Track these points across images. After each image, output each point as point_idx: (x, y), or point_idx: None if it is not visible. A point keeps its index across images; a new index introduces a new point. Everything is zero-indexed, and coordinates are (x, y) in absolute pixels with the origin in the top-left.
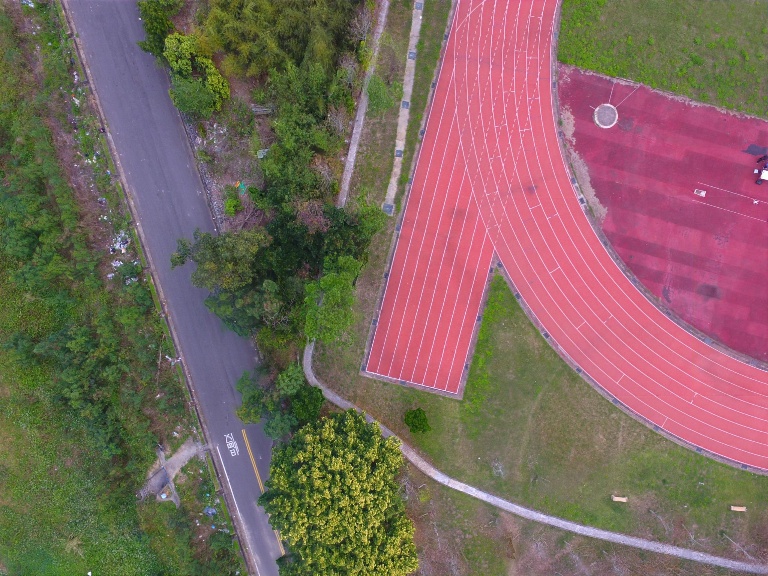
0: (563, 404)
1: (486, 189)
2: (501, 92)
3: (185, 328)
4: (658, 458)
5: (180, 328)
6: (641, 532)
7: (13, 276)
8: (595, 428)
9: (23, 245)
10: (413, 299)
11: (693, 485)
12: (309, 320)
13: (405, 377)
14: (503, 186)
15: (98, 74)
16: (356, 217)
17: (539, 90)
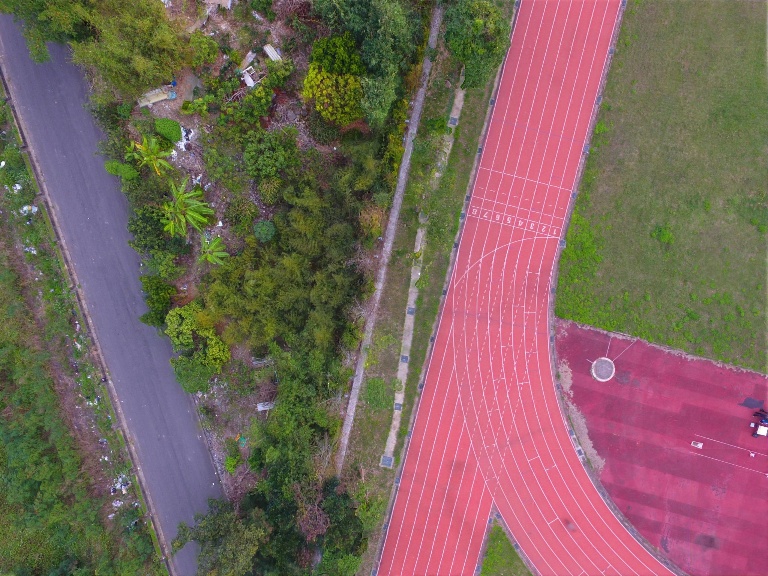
0: None
1: (485, 442)
2: (499, 347)
3: (185, 570)
4: None
5: (180, 570)
6: None
7: (14, 522)
8: None
9: (24, 491)
10: (412, 550)
11: None
12: None
13: None
14: (501, 439)
15: (100, 323)
16: (355, 470)
17: (537, 344)
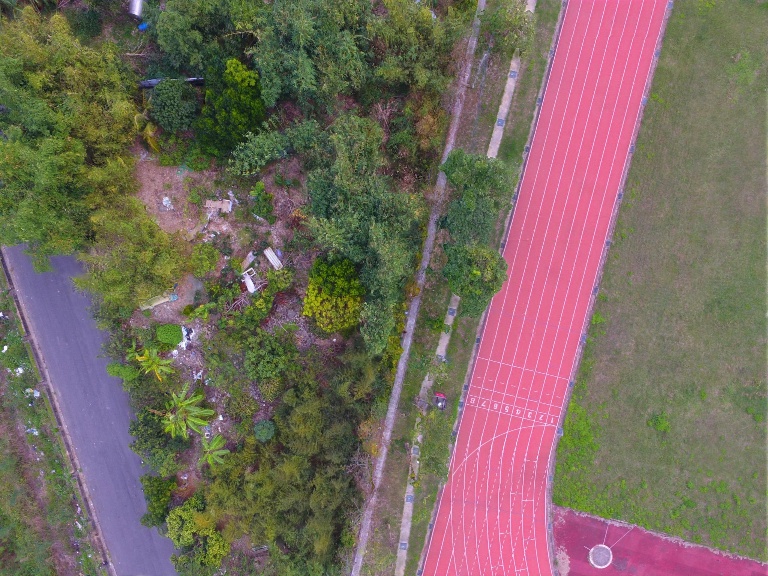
0: None
1: None
2: (497, 534)
3: None
4: None
5: None
6: None
7: None
8: None
9: None
10: None
11: None
12: None
13: None
14: None
15: (101, 507)
16: None
17: (535, 531)
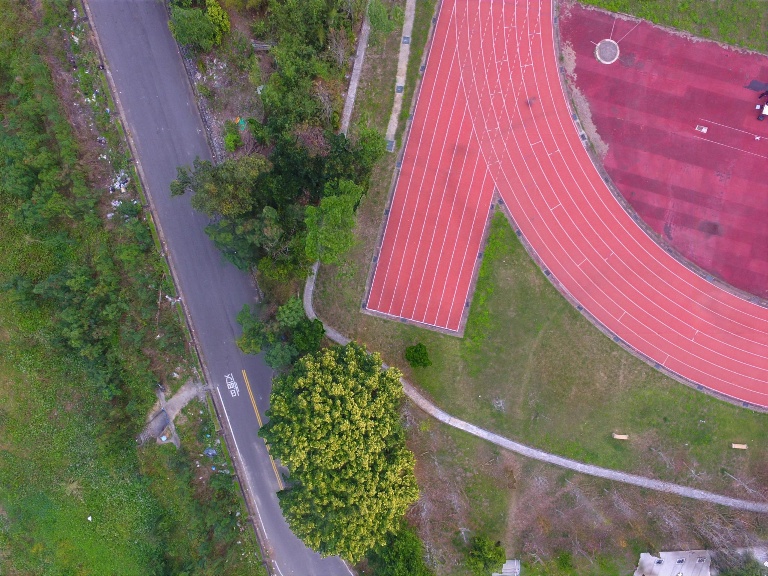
0: (564, 342)
1: (487, 125)
2: (502, 27)
3: (185, 267)
4: (659, 396)
5: (180, 267)
6: (642, 470)
7: (12, 214)
8: (596, 366)
9: (22, 183)
10: (414, 236)
11: (694, 423)
12: (310, 240)
13: (406, 314)
14: (504, 122)
15: (97, 11)
16: None
17: (540, 25)
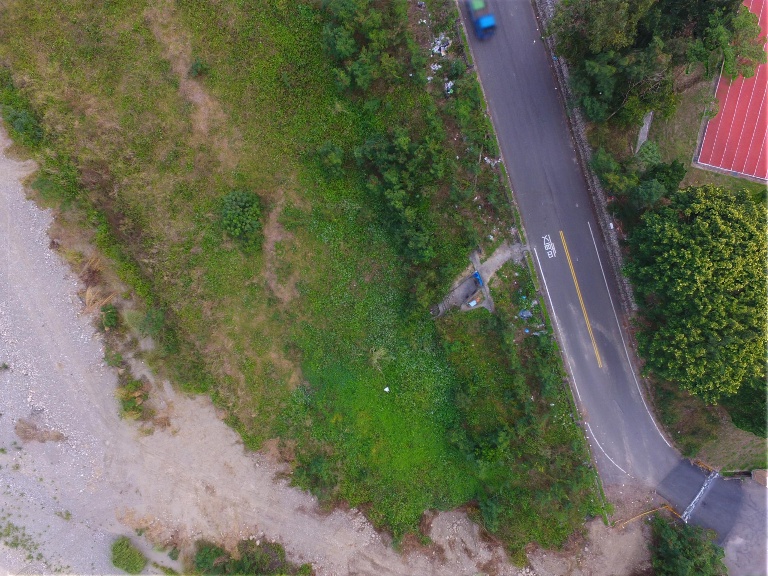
0: None
1: None
2: None
3: (506, 129)
4: None
5: (501, 129)
6: None
7: None
8: None
9: (350, 45)
10: (746, 89)
11: None
12: None
13: (737, 168)
14: None
15: None
16: None
17: None
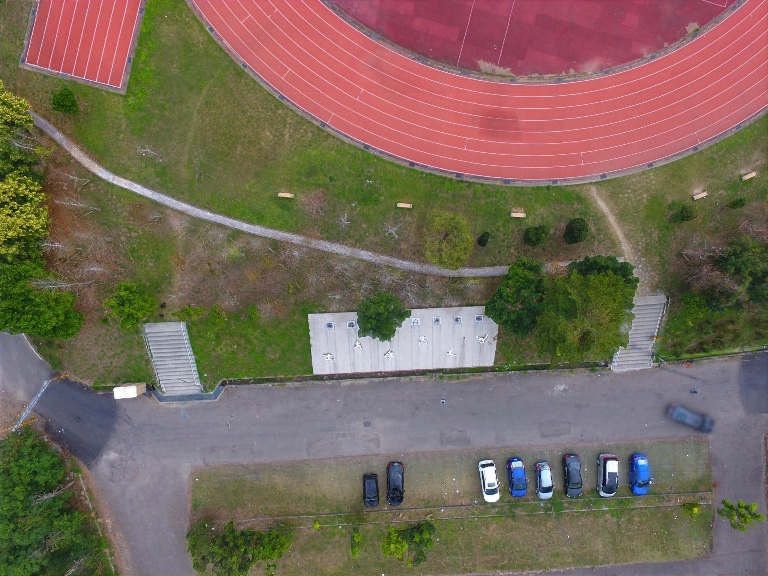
0: (229, 100)
1: None
2: None
3: None
4: (325, 155)
5: None
6: (309, 231)
7: None
8: (261, 124)
9: None
10: None
11: (360, 183)
12: None
13: (66, 69)
14: None
15: None
16: None
17: None
